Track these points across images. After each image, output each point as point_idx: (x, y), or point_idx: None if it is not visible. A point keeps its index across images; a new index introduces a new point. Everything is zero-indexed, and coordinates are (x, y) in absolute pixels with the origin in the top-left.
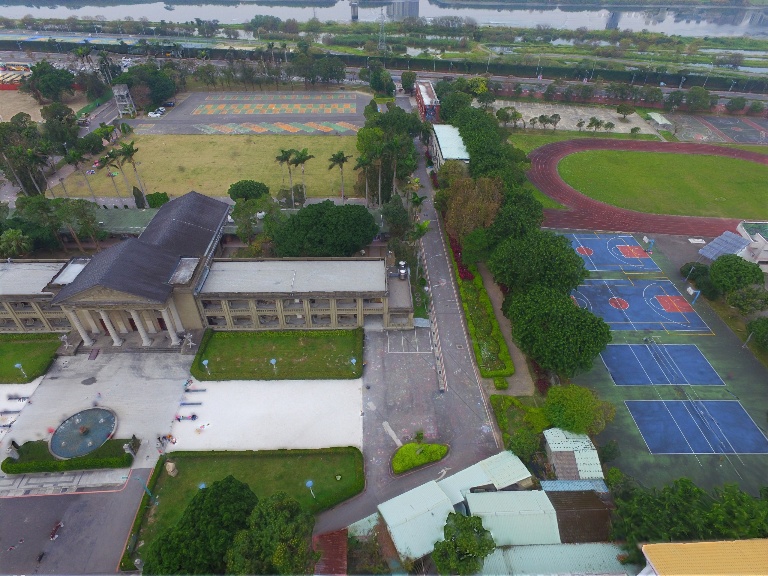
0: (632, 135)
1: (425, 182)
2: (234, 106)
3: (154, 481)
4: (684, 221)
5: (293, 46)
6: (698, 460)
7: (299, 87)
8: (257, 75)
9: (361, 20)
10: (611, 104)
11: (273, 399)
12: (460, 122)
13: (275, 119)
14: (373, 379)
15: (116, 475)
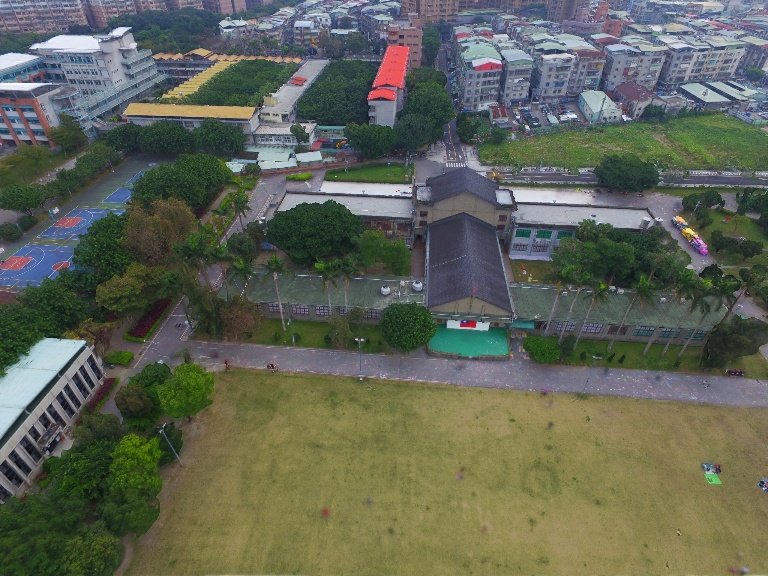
0: None
1: (114, 406)
2: None
3: None
4: None
5: None
6: None
7: None
8: None
9: None
10: None
11: None
12: None
13: None
14: None
15: None
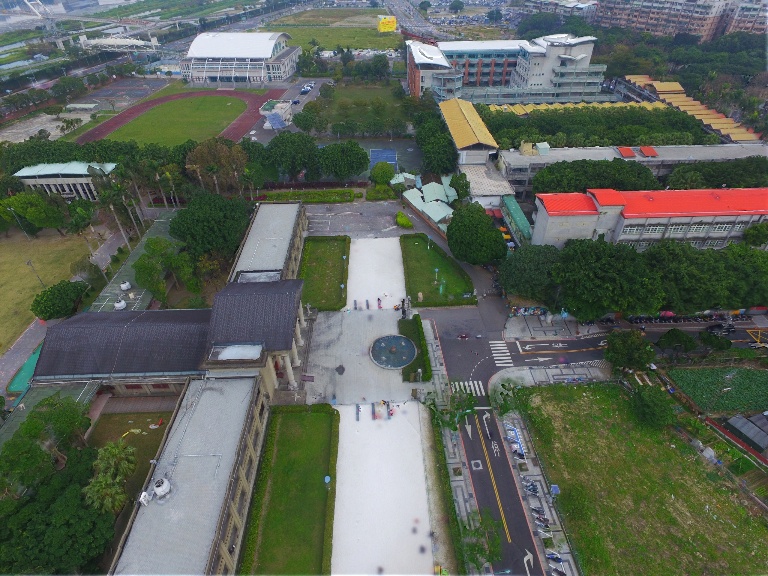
0: (94, 121)
1: None
2: None
3: (428, 302)
4: (230, 131)
5: None
6: (400, 162)
7: None
8: None
9: None
10: (19, 117)
11: (364, 271)
12: (35, 158)
13: None
14: (350, 235)
15: (425, 324)
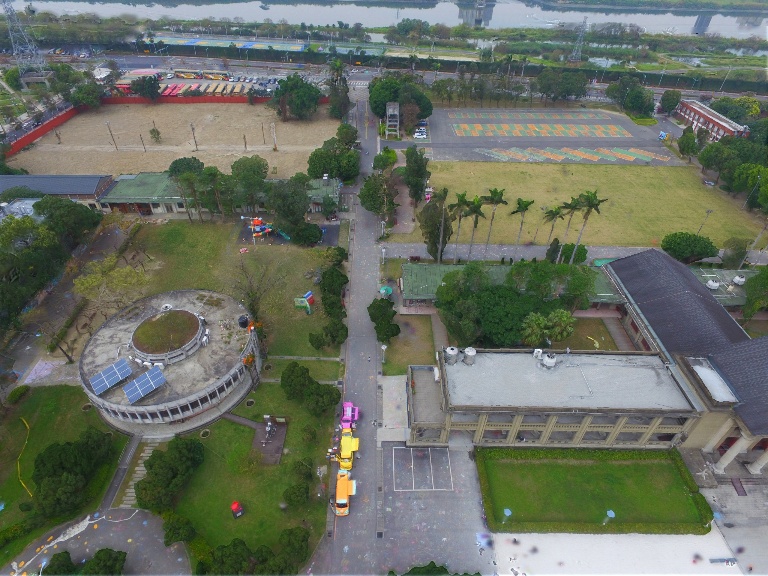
0: None
1: None
2: (492, 126)
3: None
4: None
5: (466, 54)
6: None
7: (535, 104)
8: (497, 90)
9: (561, 28)
10: None
11: None
12: None
13: (556, 143)
14: None
15: None
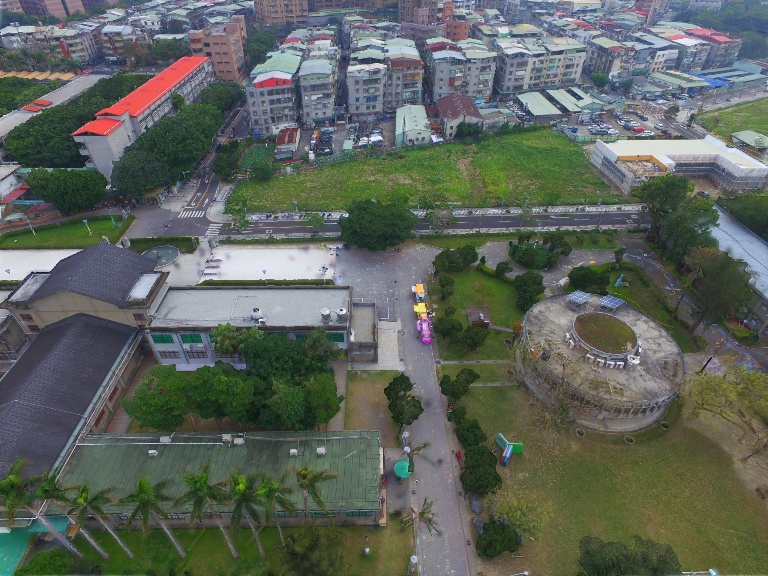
0: None
1: None
2: None
3: None
4: None
5: None
6: None
7: None
8: None
9: None
10: None
11: None
12: None
13: None
14: None
15: None
